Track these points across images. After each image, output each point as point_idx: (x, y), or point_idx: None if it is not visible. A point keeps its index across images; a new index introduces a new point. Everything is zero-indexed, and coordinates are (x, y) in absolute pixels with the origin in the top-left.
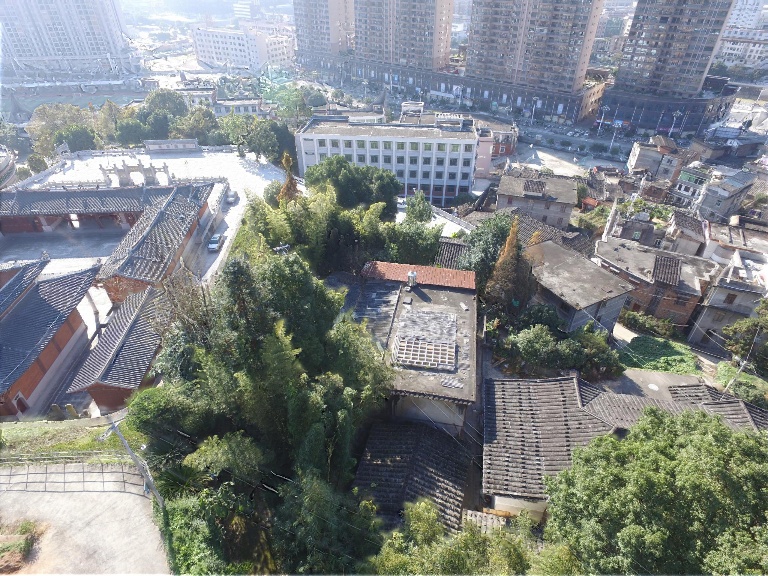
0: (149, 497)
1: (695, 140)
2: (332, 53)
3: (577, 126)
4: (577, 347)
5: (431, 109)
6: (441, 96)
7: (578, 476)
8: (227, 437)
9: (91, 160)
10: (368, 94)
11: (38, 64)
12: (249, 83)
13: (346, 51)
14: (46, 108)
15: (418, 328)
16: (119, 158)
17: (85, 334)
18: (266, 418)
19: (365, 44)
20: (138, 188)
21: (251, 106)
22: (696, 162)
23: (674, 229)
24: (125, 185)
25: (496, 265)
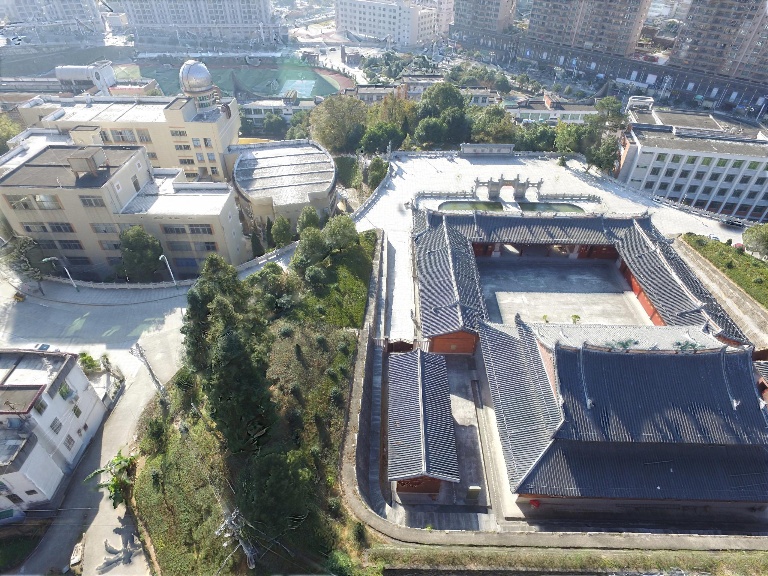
0: None
1: None
2: (497, 31)
3: None
4: None
5: (658, 105)
6: None
7: None
8: None
9: (412, 162)
10: (558, 80)
11: (190, 31)
12: None
13: (507, 28)
14: (333, 100)
15: None
16: (438, 161)
17: None
18: None
19: (542, 23)
20: (595, 218)
21: (482, 96)
22: None
23: None
24: (493, 198)
25: None
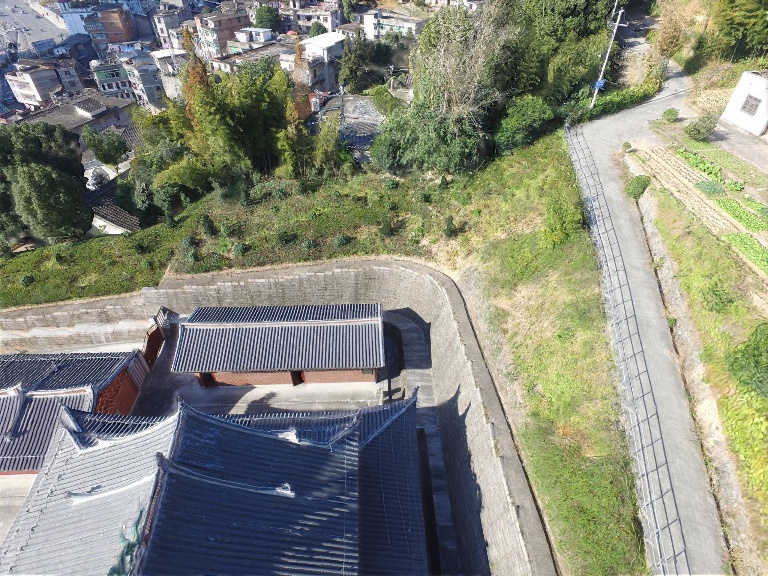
0: (582, 124)
1: None
2: None
3: None
4: None
5: None
6: None
7: (559, 8)
8: None
9: None
10: None
11: None
12: None
13: None
14: None
15: (373, 111)
16: None
17: None
18: None
19: None
20: None
21: None
22: (93, 61)
23: (230, 68)
24: None
25: (297, 87)
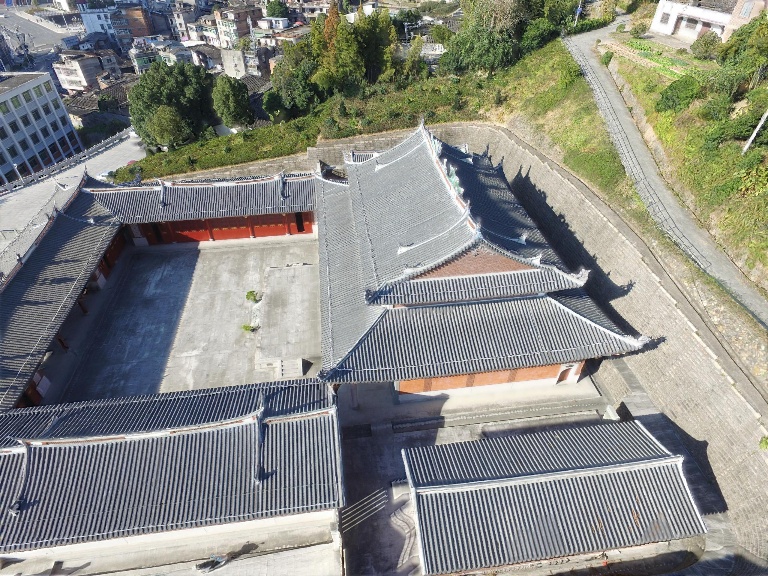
0: (570, 36)
1: None
2: None
3: None
4: None
5: None
6: None
7: None
8: None
9: None
10: None
11: None
12: None
13: None
14: None
15: None
16: None
17: None
18: None
19: None
20: (55, 221)
21: None
22: (132, 49)
23: (275, 43)
24: None
25: None
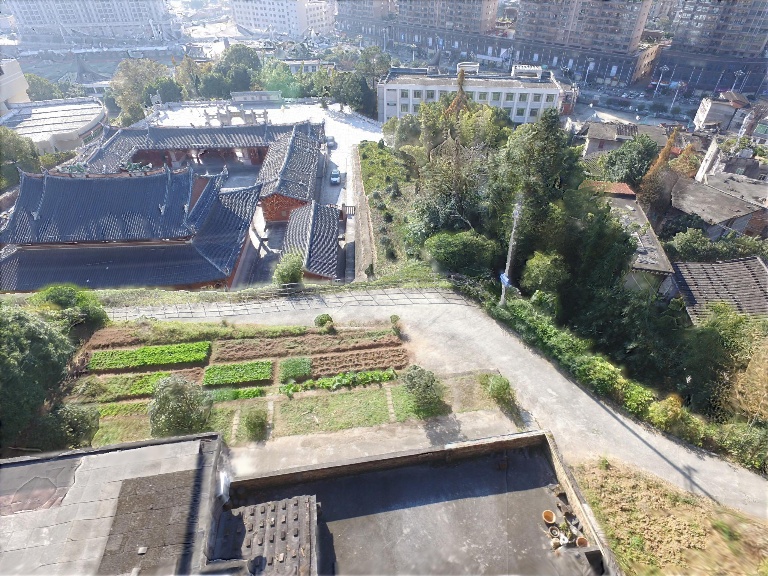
0: (474, 305)
1: (762, 98)
2: (374, 18)
3: (630, 88)
4: (733, 246)
5: (486, 70)
6: (488, 60)
7: None
8: (548, 253)
9: (182, 111)
10: (416, 57)
11: (82, 31)
12: (292, 48)
13: (387, 16)
14: (129, 63)
15: None
16: (208, 109)
17: (252, 245)
18: (558, 249)
19: (409, 7)
20: (260, 126)
21: (311, 66)
22: None
23: None
24: None
25: (644, 178)
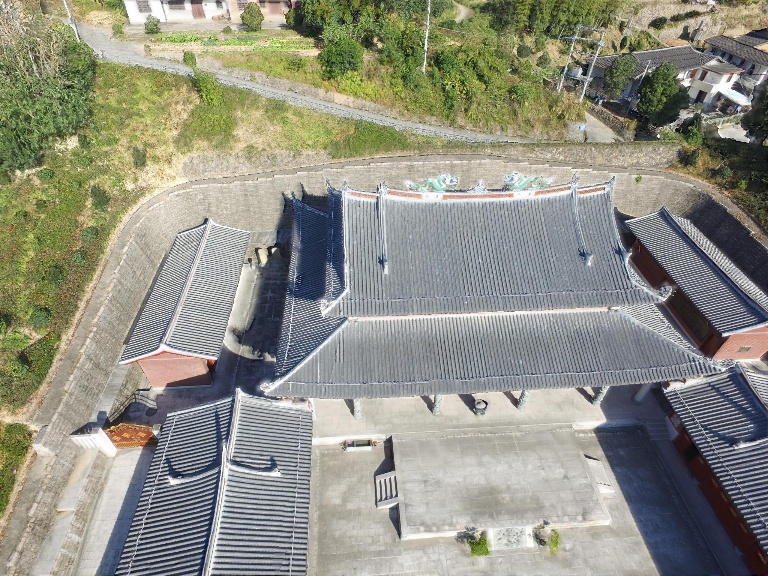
0: None
1: None
2: None
3: None
4: None
5: None
6: None
7: None
8: None
9: None
10: None
11: None
12: None
13: None
14: None
15: None
16: None
17: None
18: None
19: None
20: None
21: None
22: None
23: None
24: None
25: None
